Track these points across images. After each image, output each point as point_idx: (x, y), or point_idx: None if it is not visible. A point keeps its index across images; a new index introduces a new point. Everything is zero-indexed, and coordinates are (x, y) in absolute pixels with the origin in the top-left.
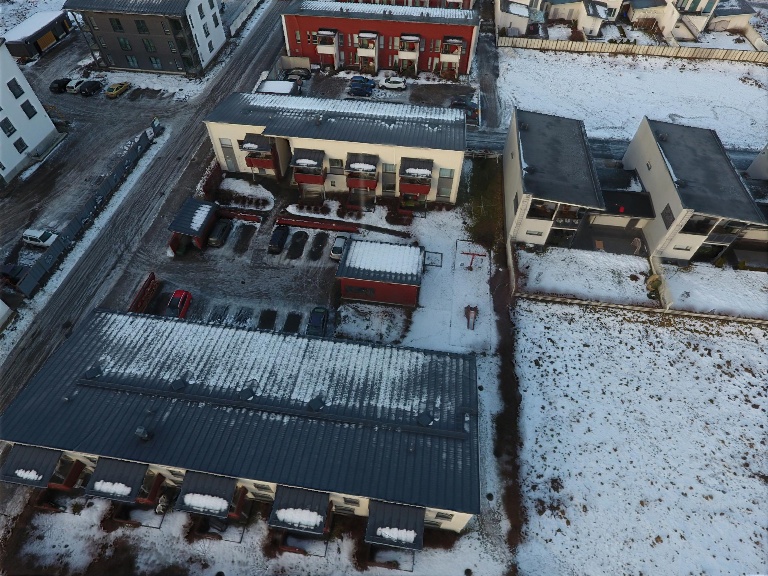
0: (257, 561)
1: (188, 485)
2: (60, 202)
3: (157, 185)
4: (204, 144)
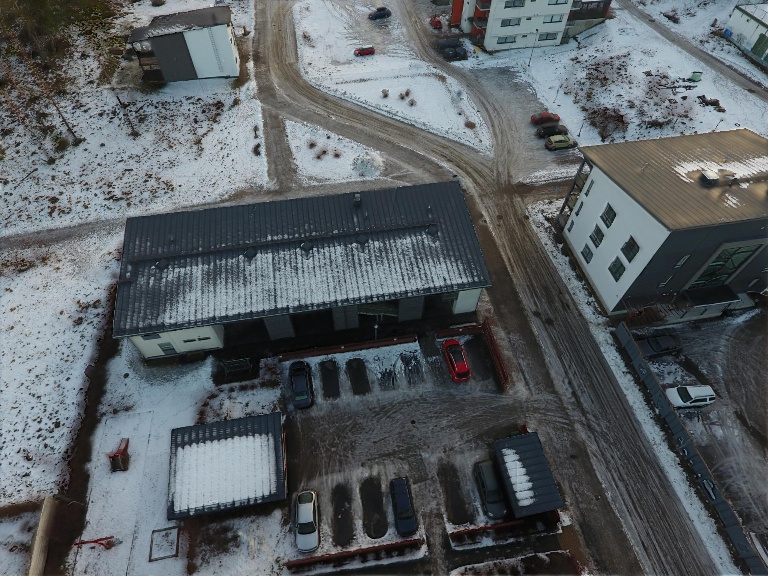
0: None
1: None
2: (762, 473)
3: (677, 572)
4: None
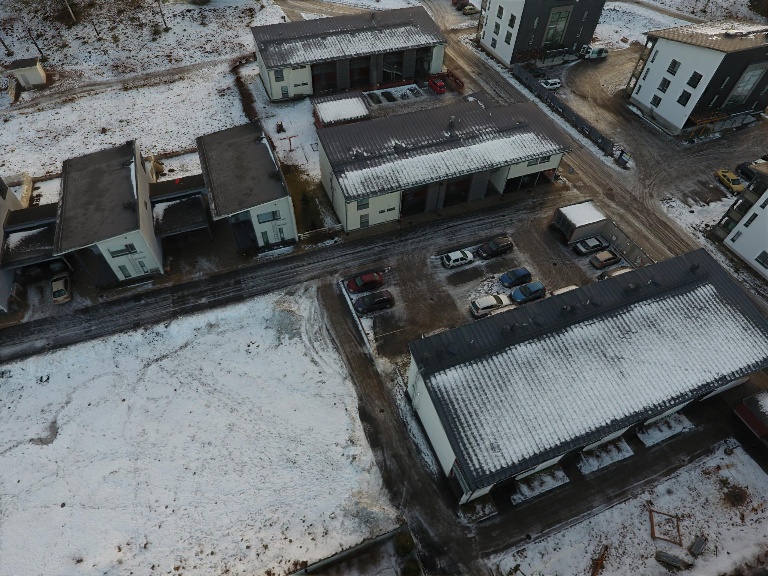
0: None
1: None
2: (583, 105)
3: None
4: (570, 167)
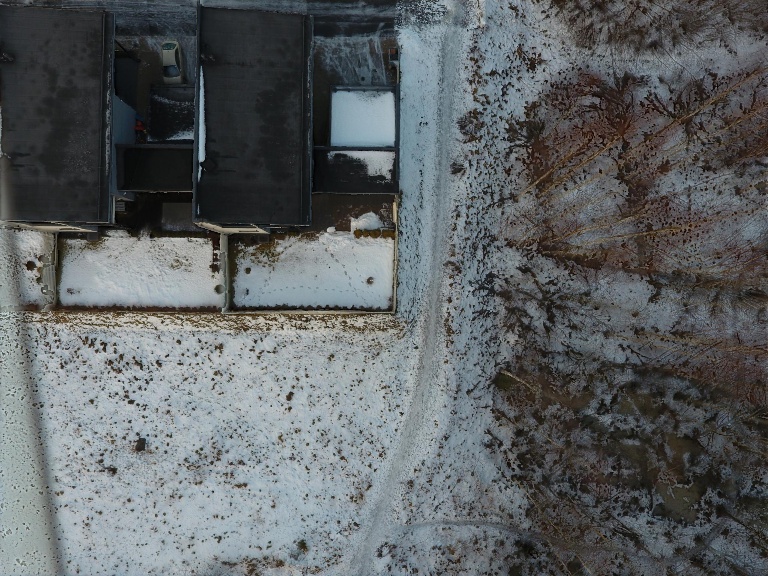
0: None
1: None
2: None
3: None
4: None
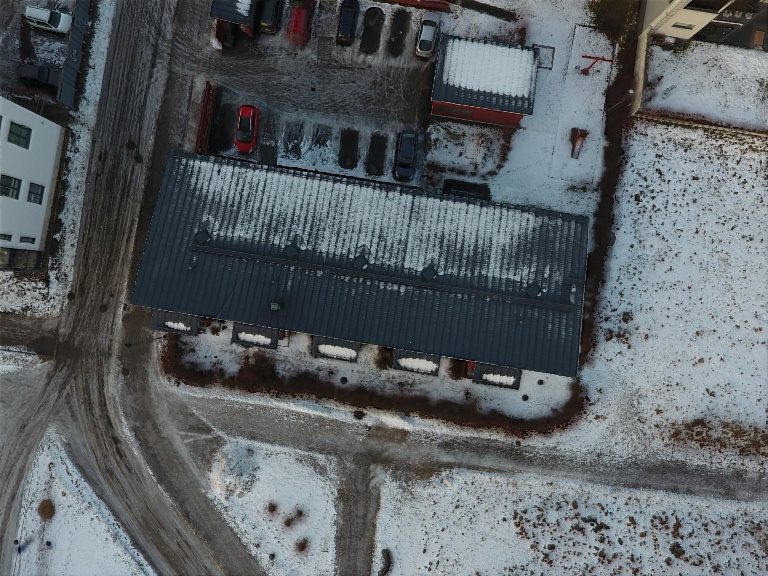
0: (372, 371)
1: (319, 338)
2: None
3: None
4: None
